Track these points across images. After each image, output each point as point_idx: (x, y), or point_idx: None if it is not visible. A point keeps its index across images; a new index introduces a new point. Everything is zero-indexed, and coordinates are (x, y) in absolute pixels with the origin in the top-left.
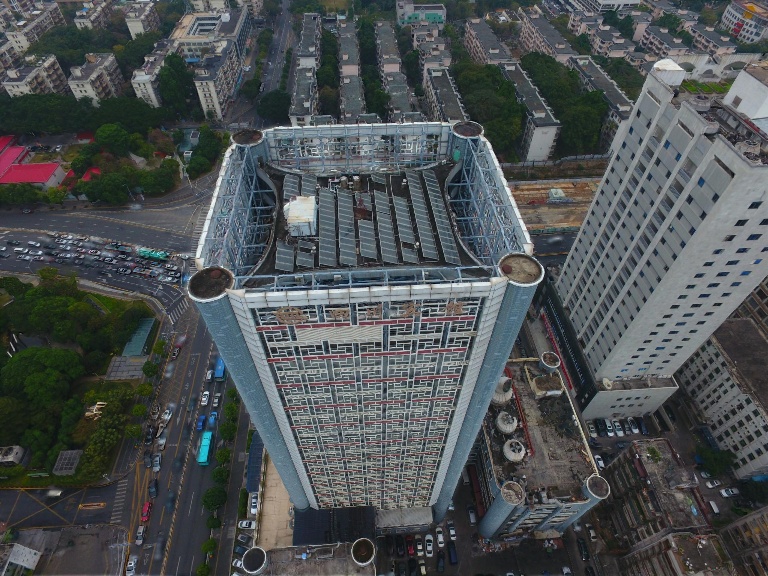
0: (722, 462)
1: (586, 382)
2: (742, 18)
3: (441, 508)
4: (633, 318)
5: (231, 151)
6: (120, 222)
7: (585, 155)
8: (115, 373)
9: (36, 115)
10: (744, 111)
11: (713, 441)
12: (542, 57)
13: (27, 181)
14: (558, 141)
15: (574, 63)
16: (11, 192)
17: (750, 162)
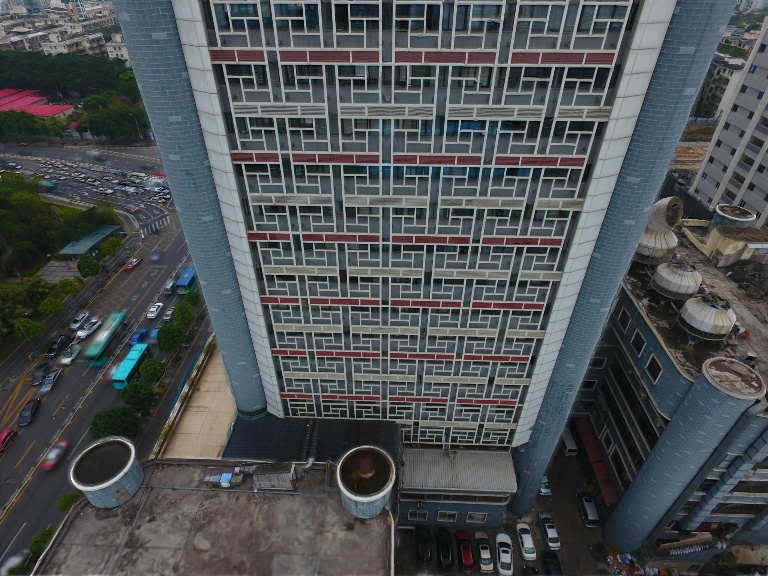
0: None
1: None
2: None
3: (536, 460)
4: None
5: None
6: (119, 156)
7: None
8: (45, 277)
9: (64, 68)
10: None
11: None
12: None
13: (31, 113)
14: None
15: None
16: (8, 117)
17: None
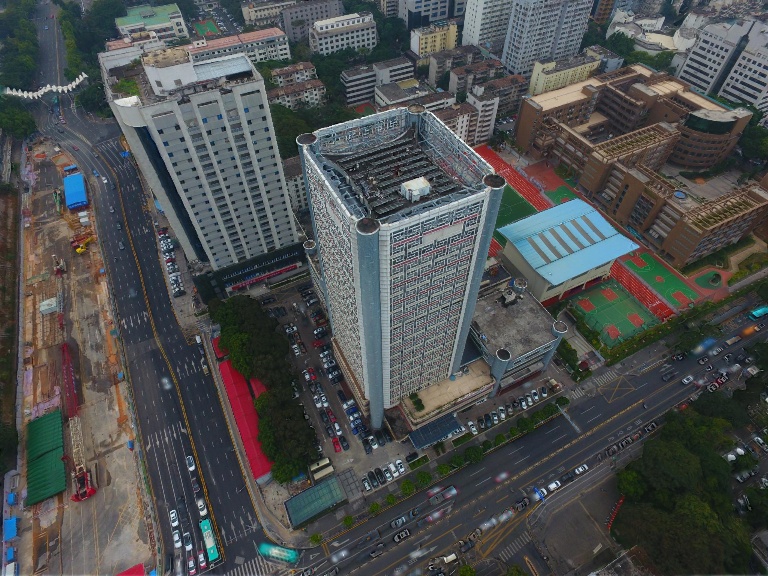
0: None
1: (299, 249)
2: None
3: None
4: (283, 194)
5: (391, 224)
6: None
7: None
8: None
9: None
10: (188, 82)
11: (307, 209)
12: None
13: None
14: None
15: None
16: None
17: (260, 79)
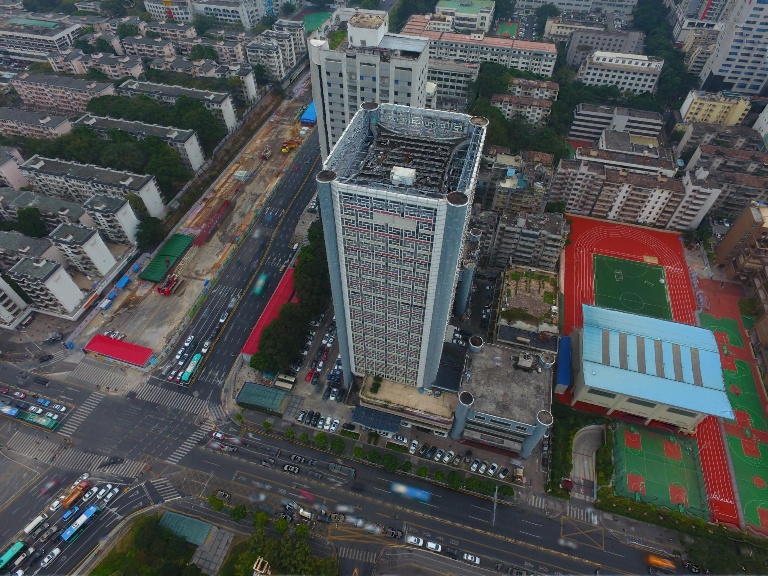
0: None
1: None
2: (165, 7)
3: None
4: None
5: (341, 183)
6: None
7: (221, 141)
8: (212, 564)
9: None
10: (371, 45)
11: None
12: (104, 99)
13: None
14: (201, 143)
15: (128, 90)
16: None
17: (415, 60)
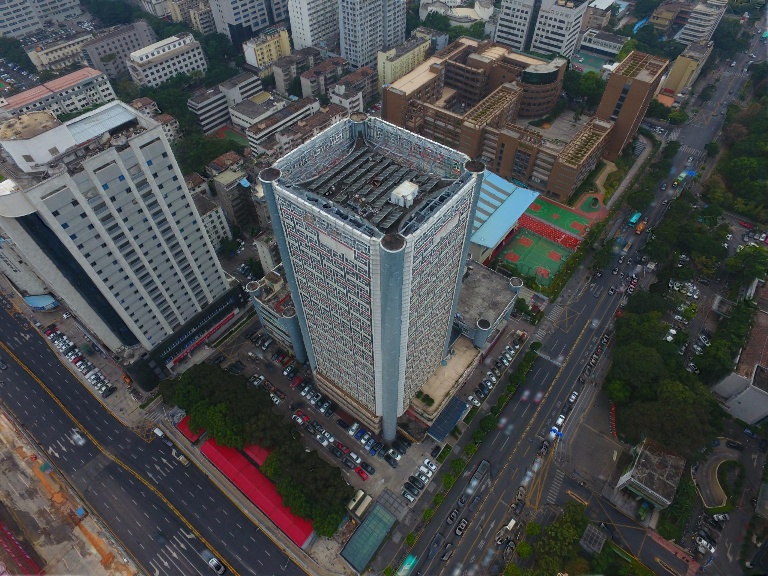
0: (229, 243)
1: None
2: None
3: None
4: (205, 243)
5: (413, 234)
6: None
7: None
8: None
9: None
10: (66, 147)
11: None
12: None
13: None
14: None
15: None
16: None
17: (157, 125)
